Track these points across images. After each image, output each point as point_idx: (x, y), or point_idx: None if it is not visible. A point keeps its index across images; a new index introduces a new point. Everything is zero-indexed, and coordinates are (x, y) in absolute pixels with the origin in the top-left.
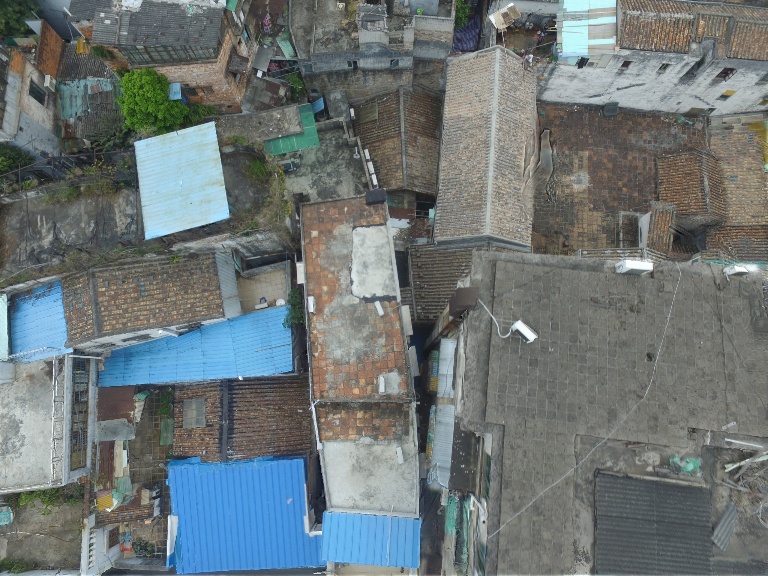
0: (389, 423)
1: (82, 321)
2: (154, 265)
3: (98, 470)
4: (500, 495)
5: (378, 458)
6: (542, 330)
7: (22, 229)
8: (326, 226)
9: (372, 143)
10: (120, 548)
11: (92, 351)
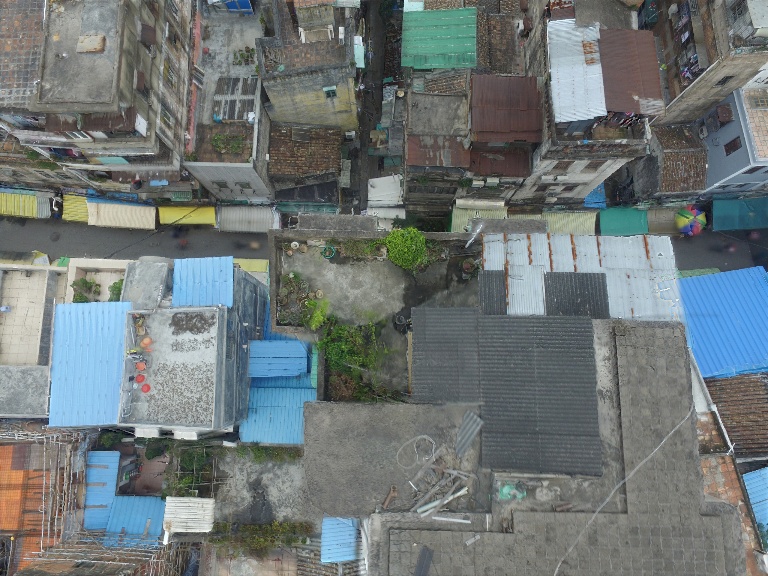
0: None
1: None
2: None
3: None
4: None
5: None
6: None
7: None
8: None
9: None
10: None
11: None
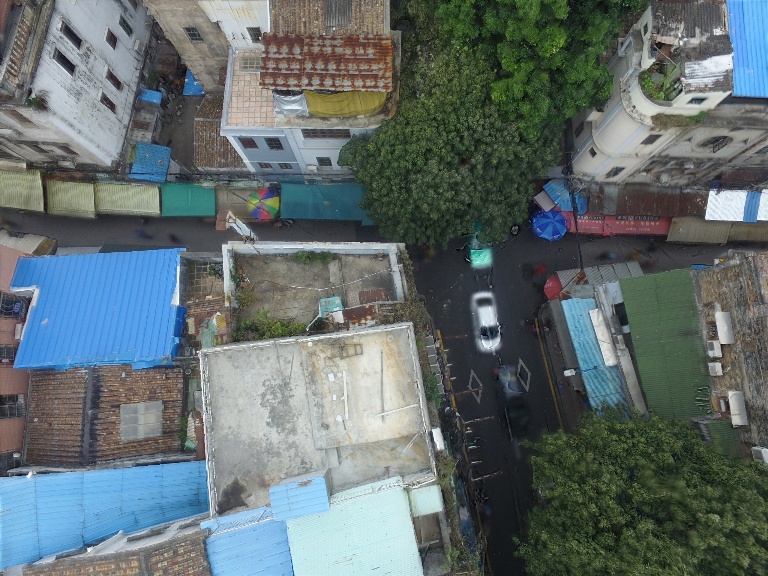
0: None
1: (173, 574)
2: None
3: None
4: None
5: None
6: None
7: None
8: None
9: None
10: None
11: None
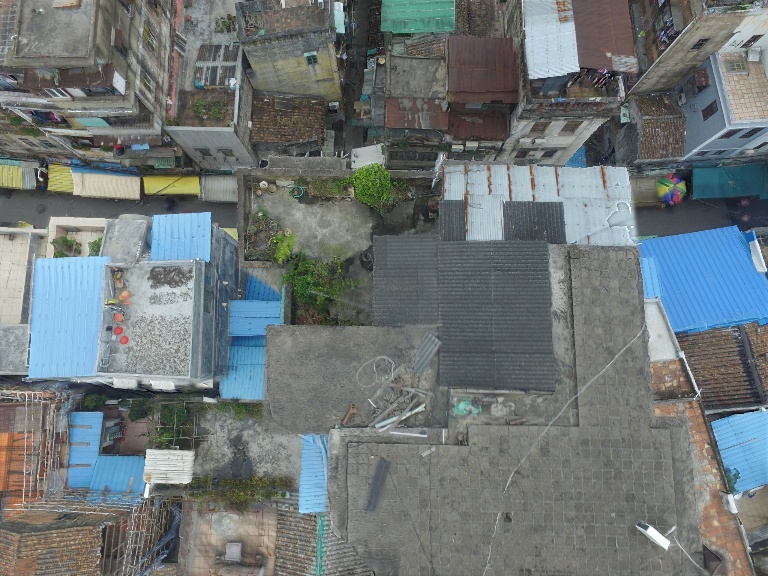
0: None
1: None
2: None
3: None
4: None
5: None
6: (625, 537)
7: None
8: None
9: None
10: None
11: None
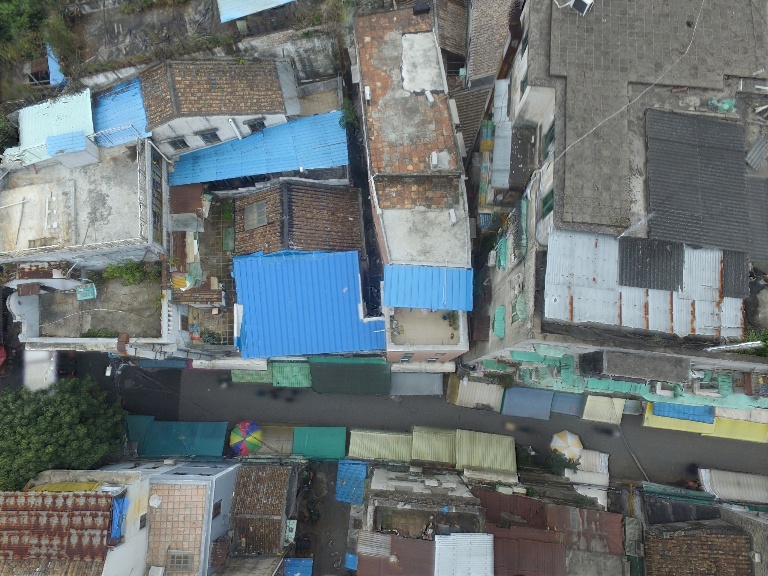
0: (441, 194)
1: (161, 106)
2: (223, 64)
3: (172, 254)
4: (564, 129)
5: (432, 222)
6: (596, 7)
7: (101, 35)
8: (378, 33)
9: (406, 6)
10: (189, 336)
11: (164, 152)
